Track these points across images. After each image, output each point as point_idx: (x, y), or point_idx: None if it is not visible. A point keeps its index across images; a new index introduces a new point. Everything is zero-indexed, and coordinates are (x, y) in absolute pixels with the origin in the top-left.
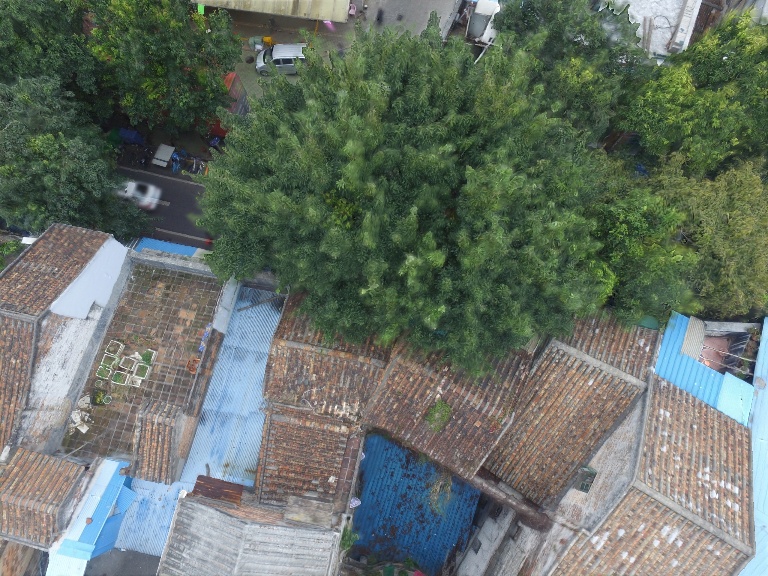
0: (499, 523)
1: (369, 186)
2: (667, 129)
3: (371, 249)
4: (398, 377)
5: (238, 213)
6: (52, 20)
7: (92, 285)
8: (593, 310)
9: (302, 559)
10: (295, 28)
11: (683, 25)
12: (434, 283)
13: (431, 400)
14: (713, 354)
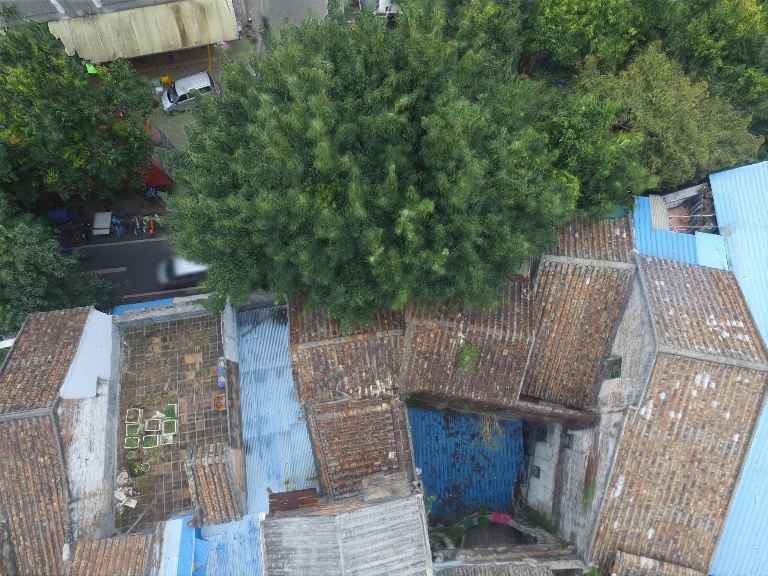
0: (550, 441)
1: (343, 161)
2: (573, 38)
3: (363, 219)
4: (419, 338)
5: (221, 234)
6: None
7: (90, 361)
8: (566, 219)
9: (397, 529)
10: (188, 61)
11: None
12: (426, 235)
13: (456, 347)
14: (677, 223)
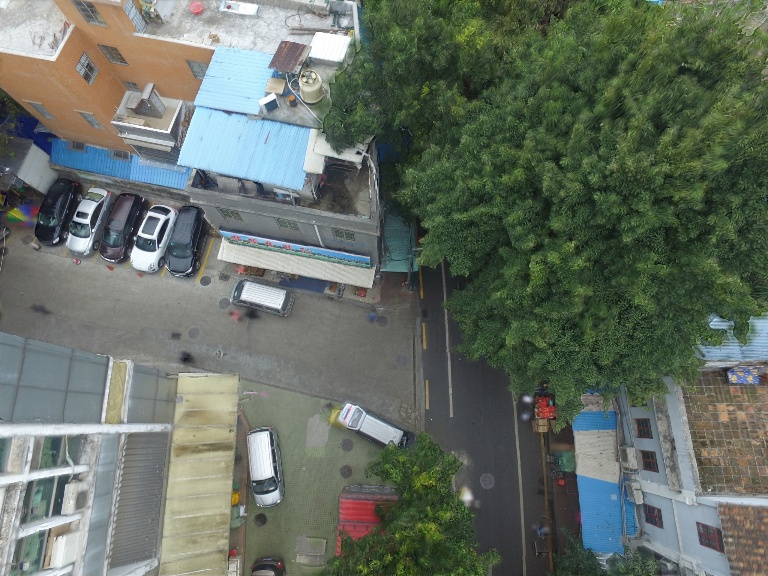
0: None
1: None
2: None
3: None
4: None
5: None
6: None
7: None
8: None
9: None
10: None
11: (305, 1)
12: None
13: None
14: None
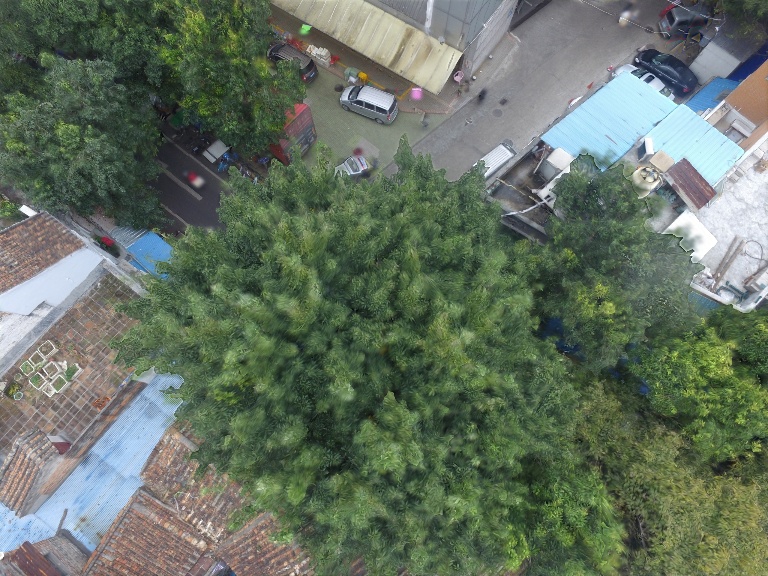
0: None
1: (260, 382)
2: (681, 398)
3: None
4: (265, 531)
5: None
6: (140, 9)
7: (46, 287)
8: None
9: None
10: None
11: None
12: (315, 483)
13: (285, 574)
14: None
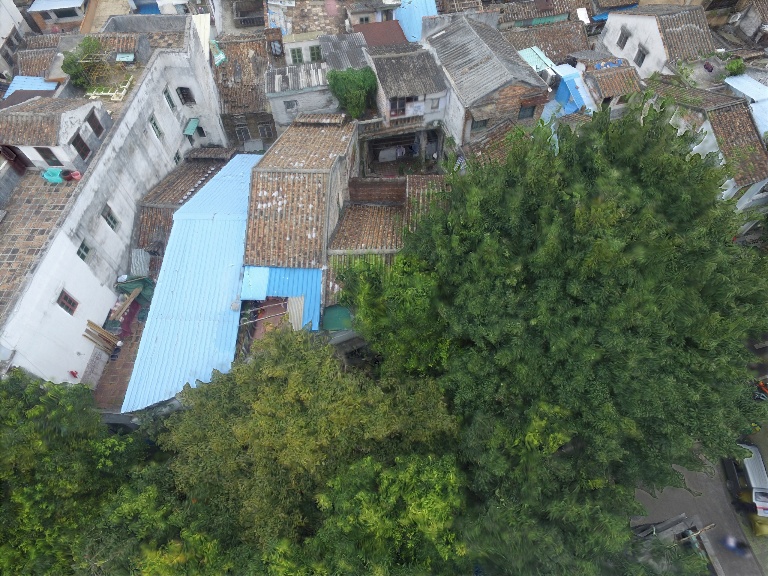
0: None
1: None
2: None
3: None
4: None
5: None
6: None
7: None
8: None
9: None
10: None
11: None
12: None
13: None
14: None
